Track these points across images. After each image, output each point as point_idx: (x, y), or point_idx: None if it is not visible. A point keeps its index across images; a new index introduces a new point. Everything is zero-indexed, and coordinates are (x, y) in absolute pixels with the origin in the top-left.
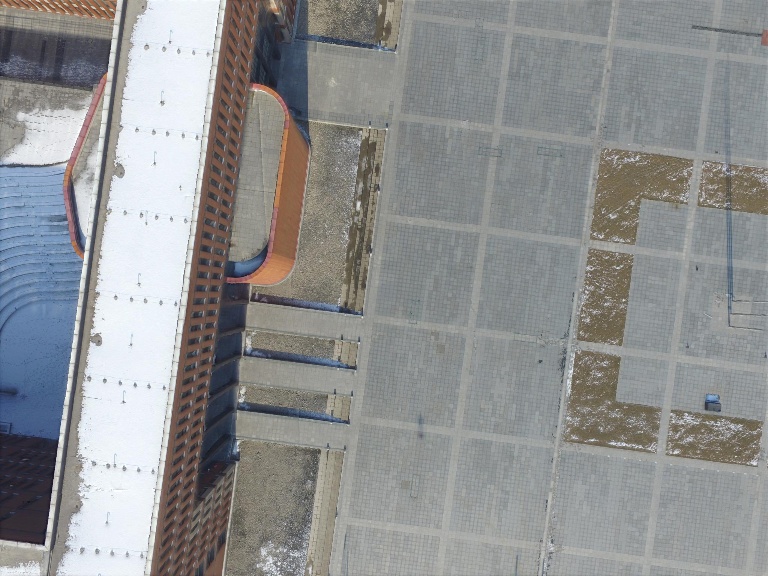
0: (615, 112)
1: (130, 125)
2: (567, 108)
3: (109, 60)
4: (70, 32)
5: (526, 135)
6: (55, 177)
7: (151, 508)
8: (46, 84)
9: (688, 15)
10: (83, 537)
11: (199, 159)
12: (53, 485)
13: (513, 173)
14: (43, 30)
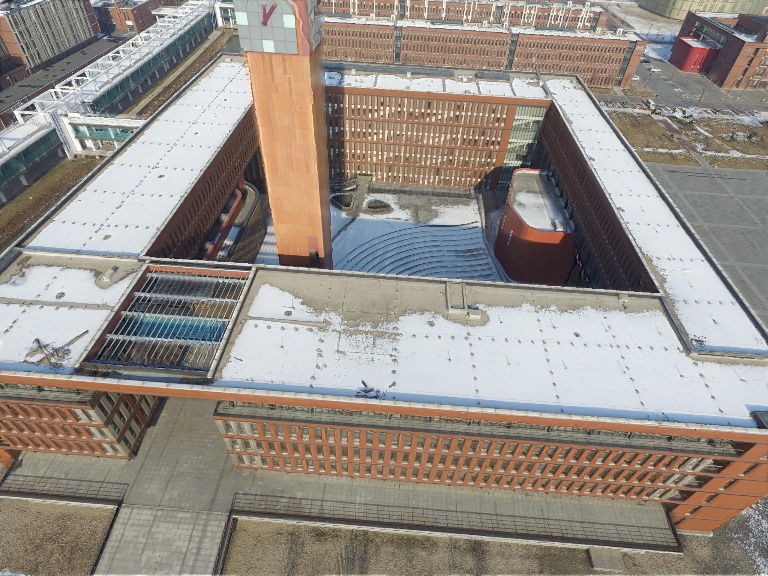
0: (763, 218)
1: (588, 147)
2: (735, 217)
3: (570, 130)
4: (438, 191)
5: (722, 226)
6: (460, 232)
7: (717, 278)
8: (447, 197)
9: (764, 188)
10: (680, 295)
11: (632, 155)
12: (643, 263)
13: (729, 240)
14: (422, 191)
